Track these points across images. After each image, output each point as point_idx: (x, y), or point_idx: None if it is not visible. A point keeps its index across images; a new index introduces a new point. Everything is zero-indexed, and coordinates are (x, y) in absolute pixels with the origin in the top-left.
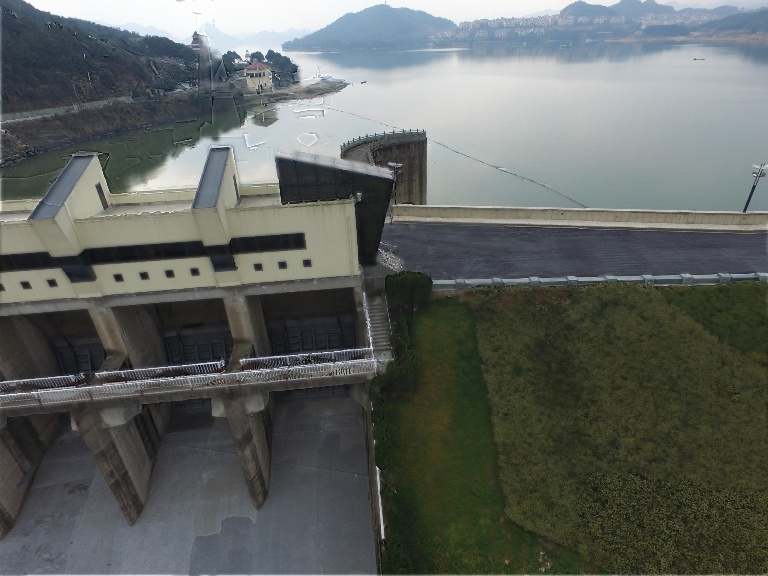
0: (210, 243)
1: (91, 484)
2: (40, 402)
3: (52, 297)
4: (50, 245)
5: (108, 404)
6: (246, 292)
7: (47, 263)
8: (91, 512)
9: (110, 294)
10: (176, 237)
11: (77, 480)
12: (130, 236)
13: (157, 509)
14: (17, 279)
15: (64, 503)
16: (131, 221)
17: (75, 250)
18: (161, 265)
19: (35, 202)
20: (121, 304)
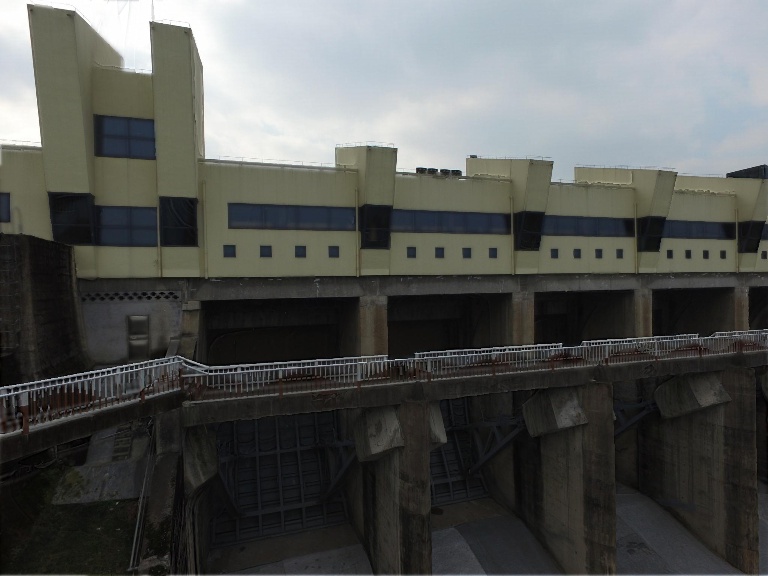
0: (756, 218)
1: (644, 540)
2: (700, 353)
3: (615, 270)
4: (656, 201)
5: (754, 361)
6: (750, 282)
7: (620, 231)
8: (688, 571)
9: (659, 272)
10: (716, 217)
11: (622, 538)
12: (686, 211)
13: (760, 557)
14: (594, 246)
15: (641, 566)
16: (690, 196)
17: (668, 210)
18: (701, 244)
19: None
20: (661, 286)
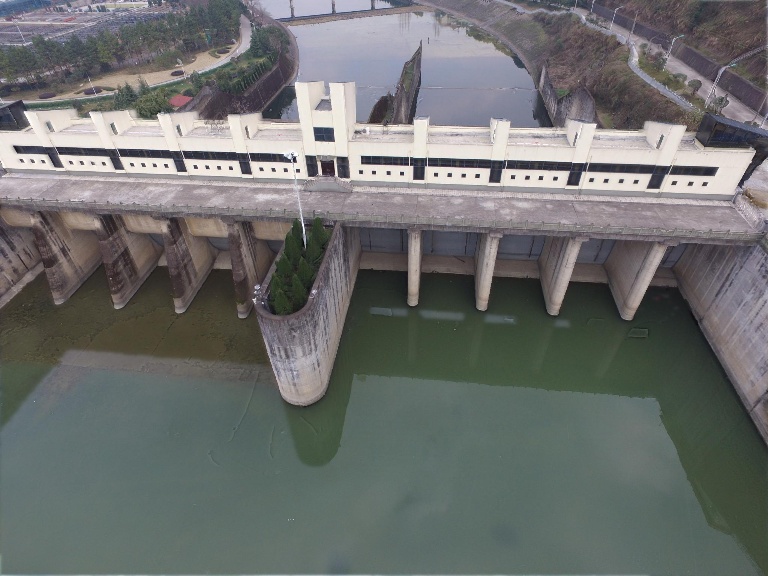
0: None
1: None
2: None
3: None
4: None
5: None
6: None
7: None
8: None
9: None
10: None
11: None
12: None
13: None
14: None
15: None
16: None
17: None
18: None
19: (137, 136)
20: None
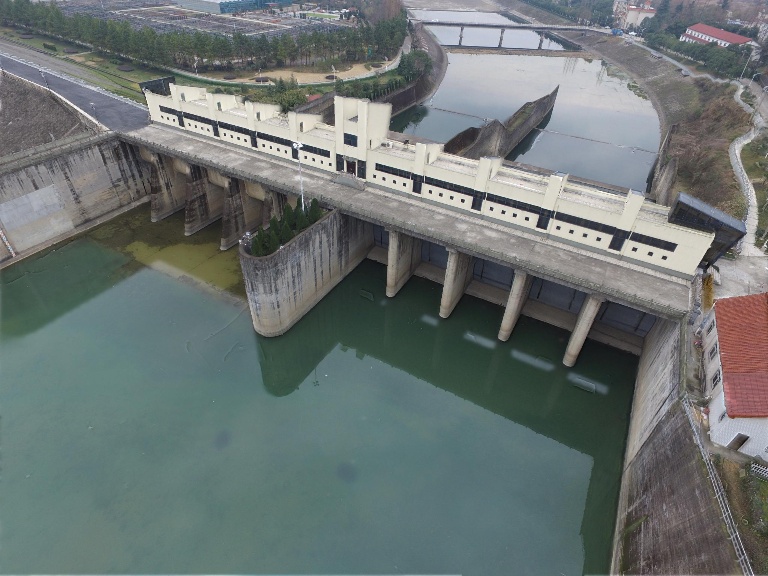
0: None
1: None
2: None
3: None
4: None
5: None
6: None
7: None
8: None
9: None
10: None
11: None
12: None
13: None
14: None
15: None
16: None
17: None
18: None
19: None
20: None
